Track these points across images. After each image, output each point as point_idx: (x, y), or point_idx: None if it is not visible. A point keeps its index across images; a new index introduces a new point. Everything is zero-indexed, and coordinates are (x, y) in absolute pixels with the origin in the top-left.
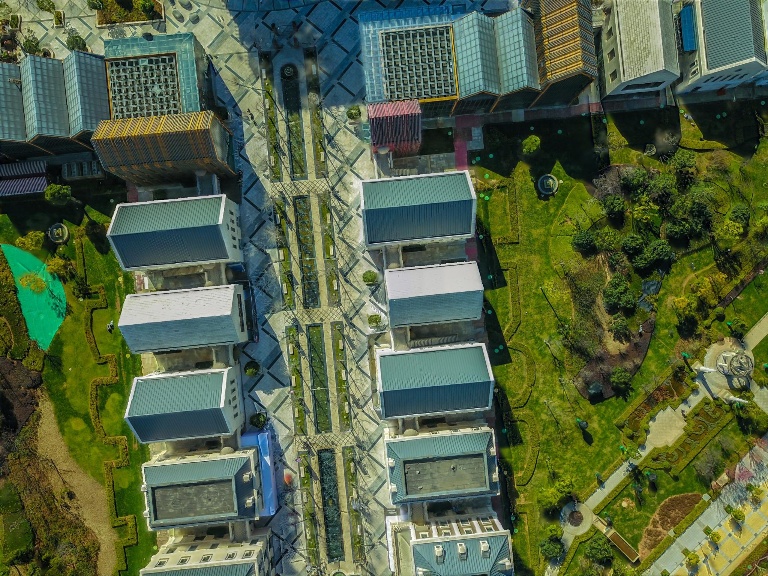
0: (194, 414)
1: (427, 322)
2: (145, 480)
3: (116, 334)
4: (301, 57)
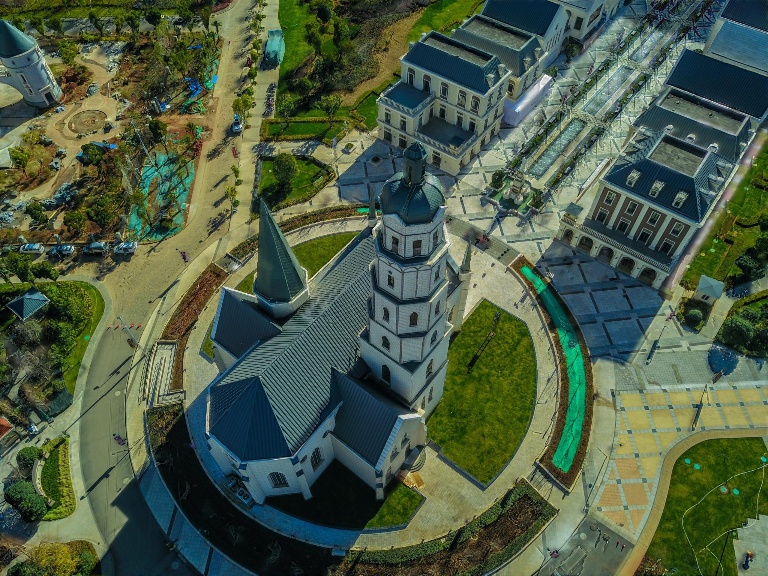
0: (538, 3)
1: (739, 62)
2: None
3: None
4: None
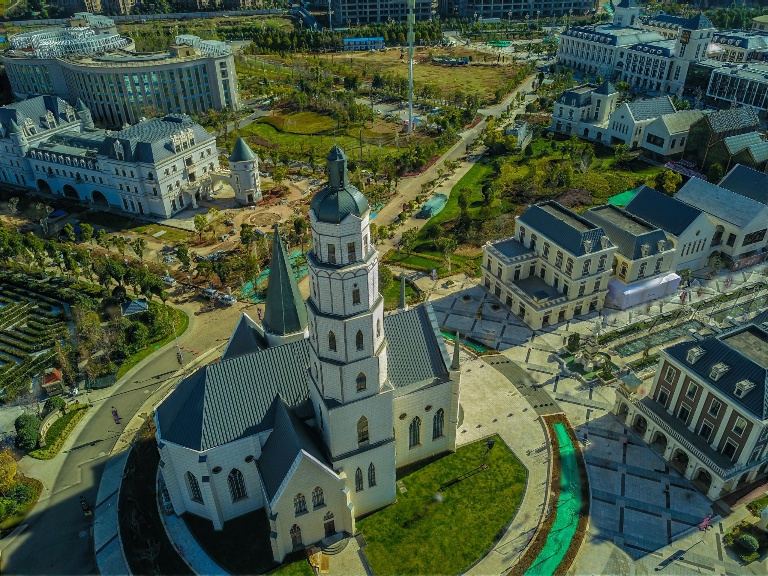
0: (681, 207)
1: None
2: None
3: None
4: None
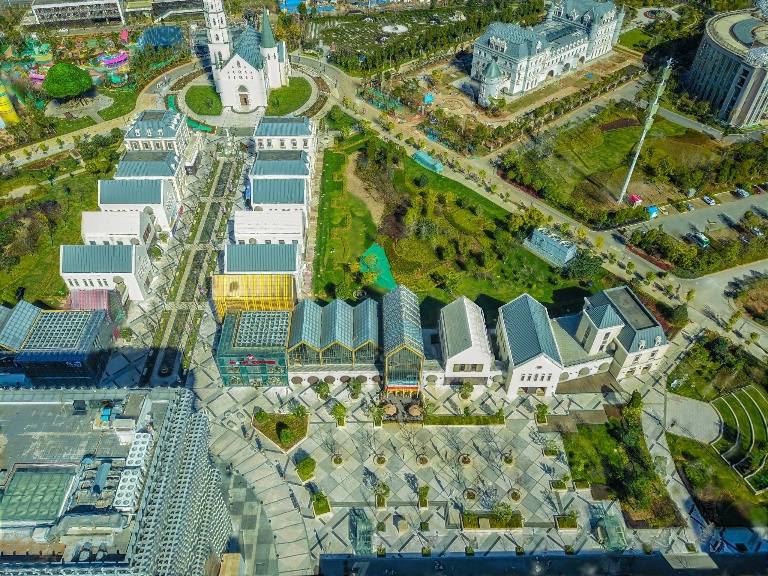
0: None
1: None
2: (309, 171)
3: (330, 247)
4: (152, 381)
